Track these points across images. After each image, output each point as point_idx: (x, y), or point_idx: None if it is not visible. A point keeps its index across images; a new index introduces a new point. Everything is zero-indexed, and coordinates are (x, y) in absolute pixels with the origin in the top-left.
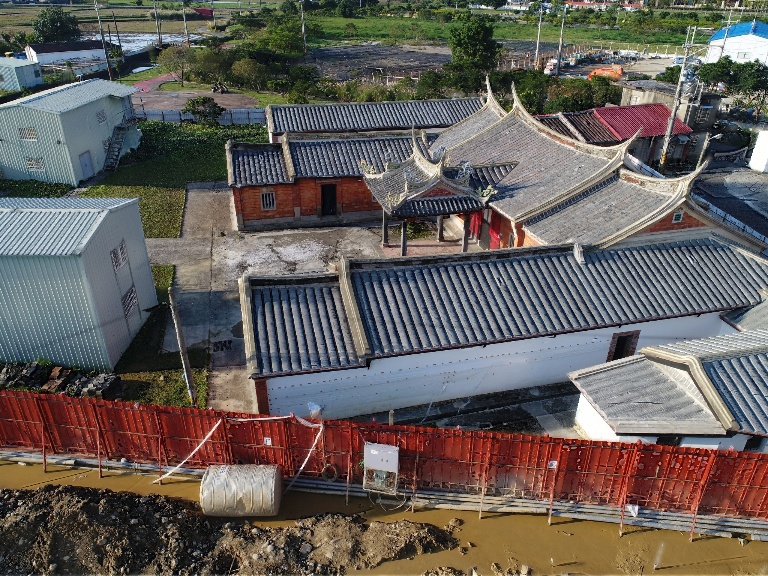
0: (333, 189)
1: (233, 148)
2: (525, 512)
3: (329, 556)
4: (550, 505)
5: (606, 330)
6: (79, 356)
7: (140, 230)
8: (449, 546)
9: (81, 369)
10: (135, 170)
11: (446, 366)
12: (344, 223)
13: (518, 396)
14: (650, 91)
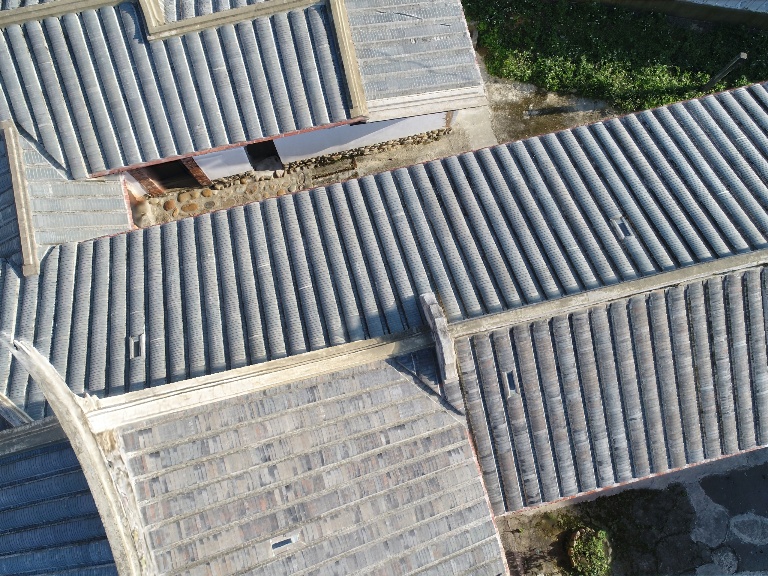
0: None
1: None
2: None
3: None
4: None
5: None
6: None
7: None
8: None
9: None
10: None
11: None
12: None
13: None
14: None
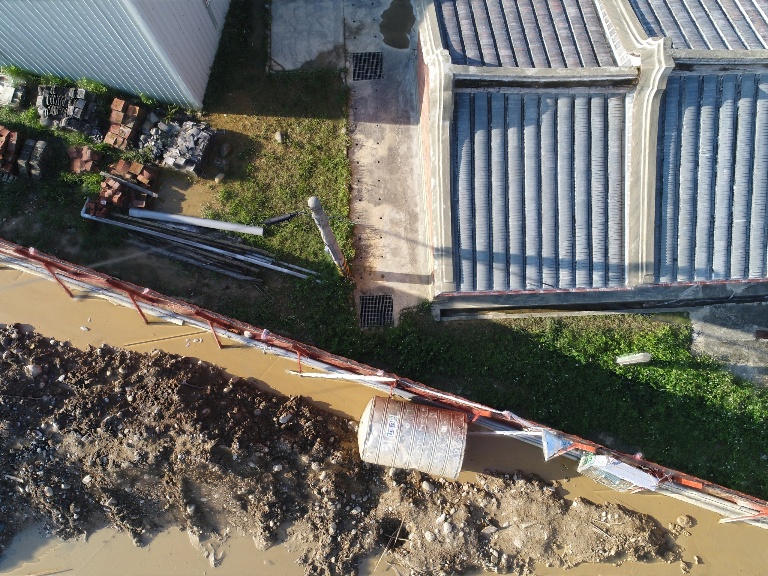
0: None
1: None
2: None
3: (517, 545)
4: None
5: None
6: (146, 86)
7: None
8: (670, 559)
9: (153, 101)
10: None
11: None
12: None
13: None
14: None
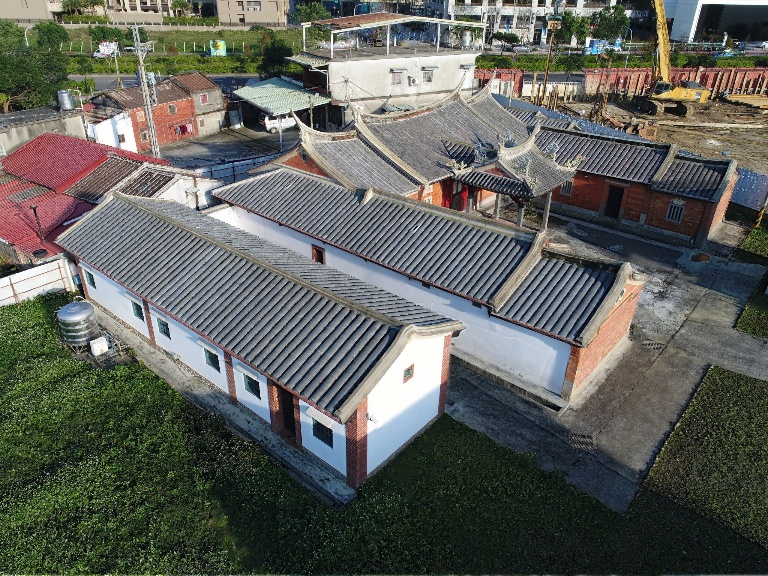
0: None
1: None
2: None
3: None
4: None
5: None
6: None
7: None
8: None
9: None
10: None
11: None
12: None
13: None
14: (21, 126)
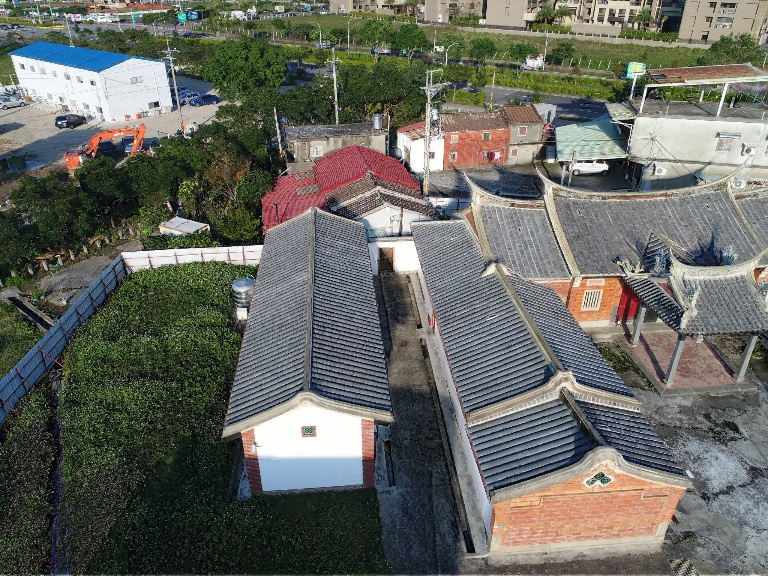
0: None
1: None
2: None
3: None
4: None
5: None
6: None
7: None
8: None
9: None
10: None
11: None
12: None
13: None
14: (337, 137)
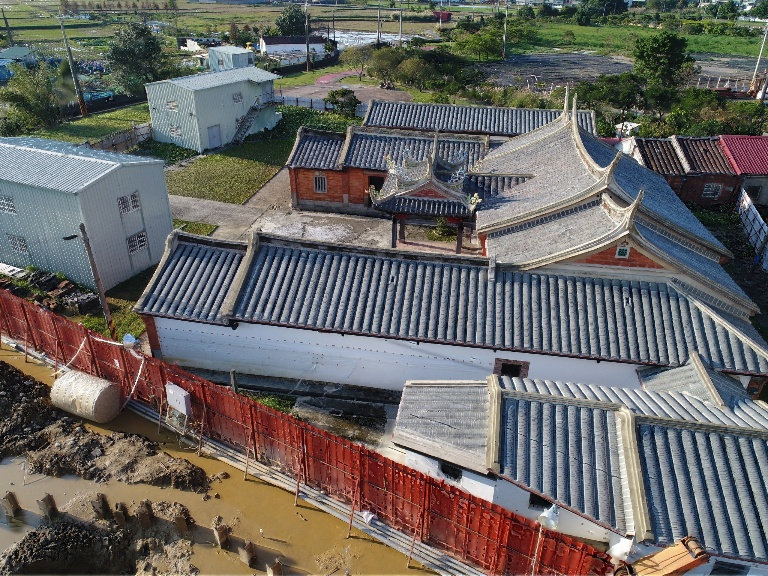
0: (382, 182)
1: (304, 133)
2: (280, 486)
3: (107, 464)
4: (297, 486)
5: (482, 351)
6: (82, 276)
7: (163, 187)
8: (198, 490)
9: (83, 287)
10: (255, 146)
11: (314, 347)
12: (388, 216)
13: (389, 397)
14: None
